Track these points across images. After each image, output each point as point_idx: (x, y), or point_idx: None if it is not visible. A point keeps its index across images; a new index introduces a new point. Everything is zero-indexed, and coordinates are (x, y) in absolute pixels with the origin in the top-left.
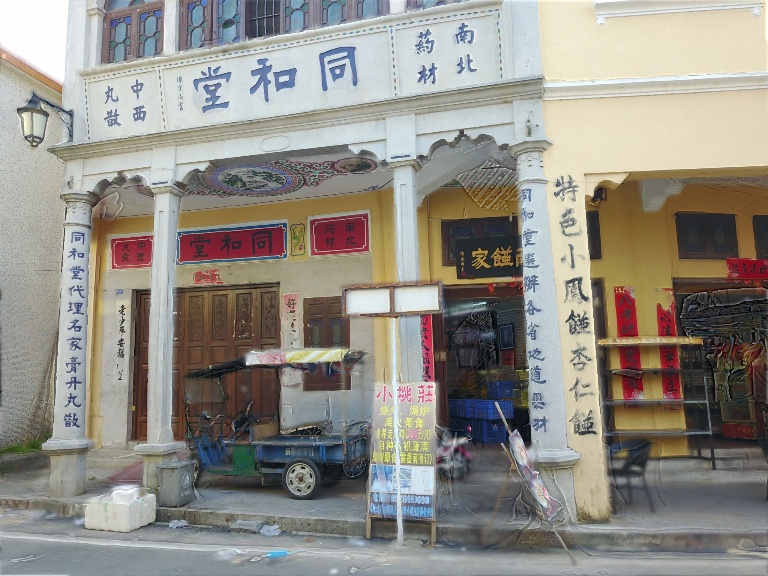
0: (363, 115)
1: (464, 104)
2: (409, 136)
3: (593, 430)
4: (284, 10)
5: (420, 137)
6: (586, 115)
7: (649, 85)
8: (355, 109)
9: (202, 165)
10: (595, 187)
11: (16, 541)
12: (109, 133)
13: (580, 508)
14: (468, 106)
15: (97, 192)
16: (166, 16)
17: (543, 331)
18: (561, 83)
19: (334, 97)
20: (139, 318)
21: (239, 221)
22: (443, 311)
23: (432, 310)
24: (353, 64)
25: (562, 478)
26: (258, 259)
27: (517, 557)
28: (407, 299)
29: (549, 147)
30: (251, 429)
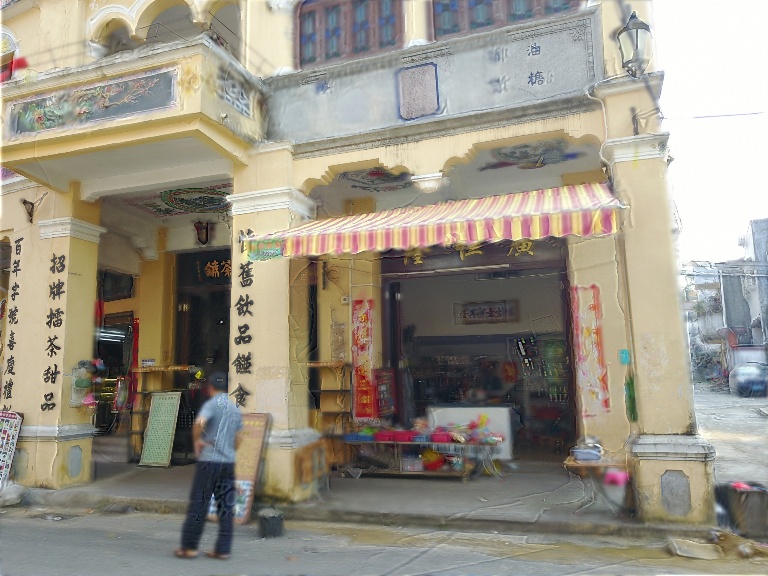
0: None
1: None
2: None
3: None
4: None
5: None
6: None
7: None
8: None
9: None
10: None
11: None
12: None
13: None
14: None
15: None
16: None
17: None
18: None
19: None
20: None
21: (4, 296)
22: None
23: None
24: None
25: None
26: None
27: None
28: None
29: None
30: None
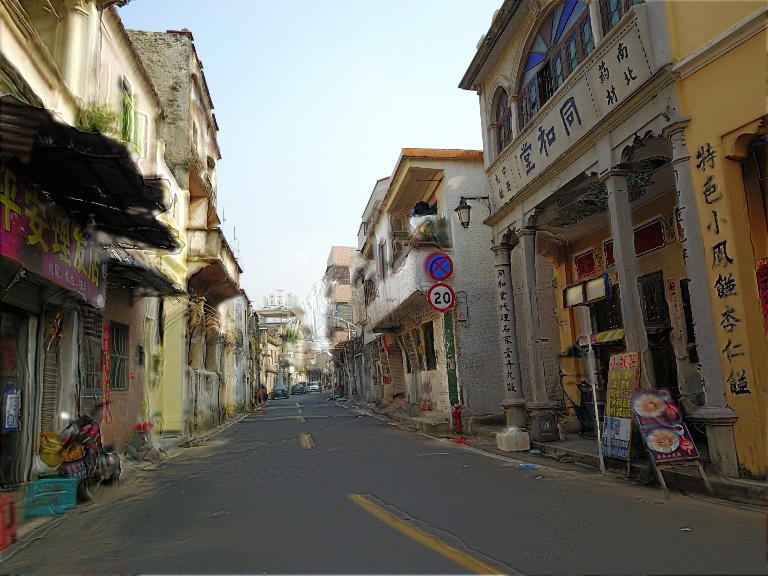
0: (585, 146)
1: (632, 111)
2: (607, 152)
3: (748, 389)
4: (555, 80)
5: (615, 150)
6: (717, 76)
7: (765, 16)
8: (579, 144)
9: (532, 211)
10: (745, 141)
11: (461, 449)
12: (502, 203)
13: (741, 464)
14: (635, 111)
15: (505, 242)
16: (512, 115)
17: (693, 299)
18: (685, 60)
19: (574, 138)
20: (597, 313)
21: (634, 224)
22: (607, 296)
23: (603, 296)
24: (575, 109)
25: (720, 434)
26: (648, 252)
27: (637, 488)
28: (592, 290)
29: (689, 123)
30: (589, 393)
